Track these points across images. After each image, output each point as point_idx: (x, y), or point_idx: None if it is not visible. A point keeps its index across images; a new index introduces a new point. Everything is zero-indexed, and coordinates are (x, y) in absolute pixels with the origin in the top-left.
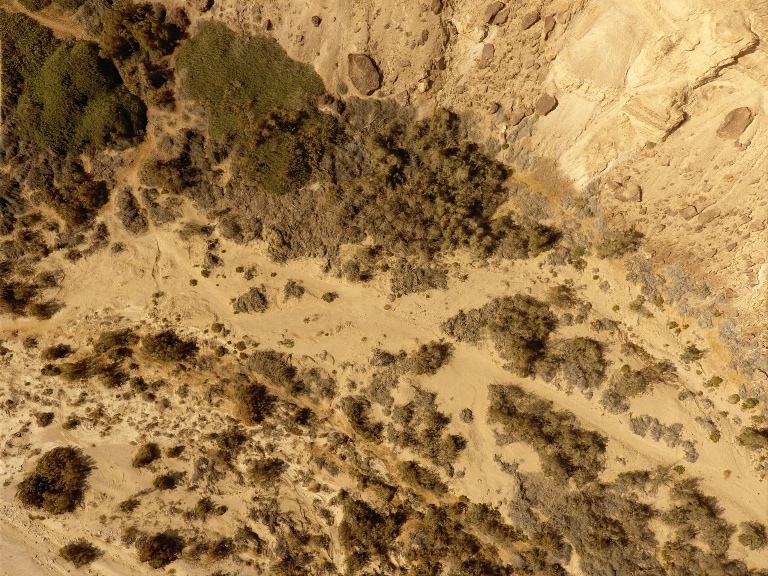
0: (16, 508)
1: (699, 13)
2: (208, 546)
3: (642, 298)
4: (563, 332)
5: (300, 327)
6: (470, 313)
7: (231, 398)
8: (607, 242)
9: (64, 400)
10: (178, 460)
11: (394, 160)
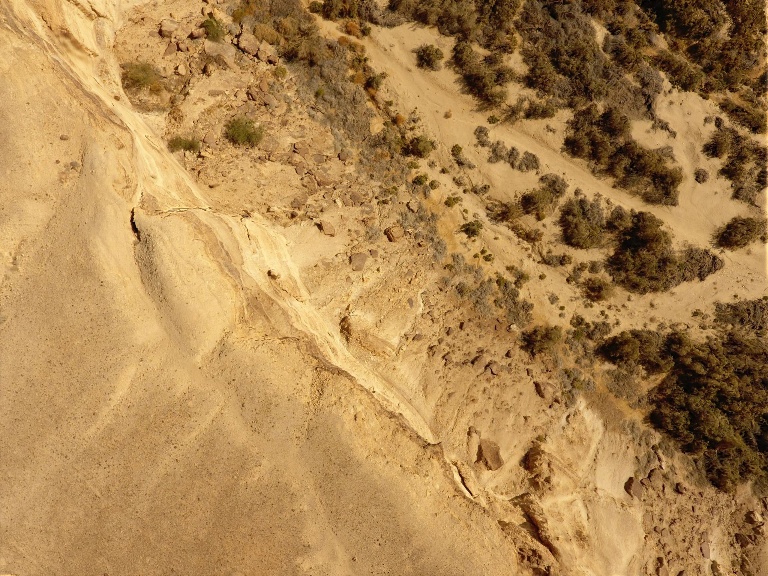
0: None
1: (585, 572)
2: None
3: (519, 286)
4: (600, 255)
5: None
6: None
7: None
8: None
9: None
10: None
11: None
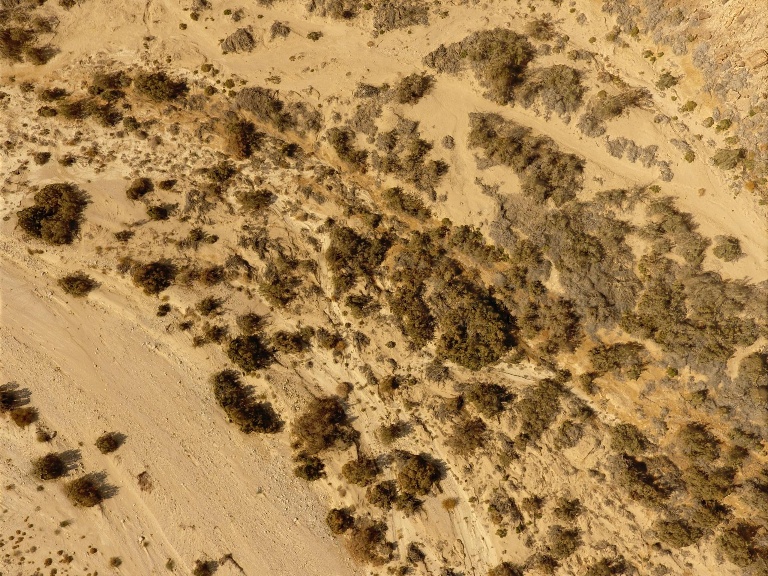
0: (16, 243)
1: None
2: (200, 273)
3: (618, 28)
4: (541, 61)
5: (286, 65)
6: (451, 45)
7: (221, 134)
8: None
9: (60, 139)
10: (170, 192)
11: None
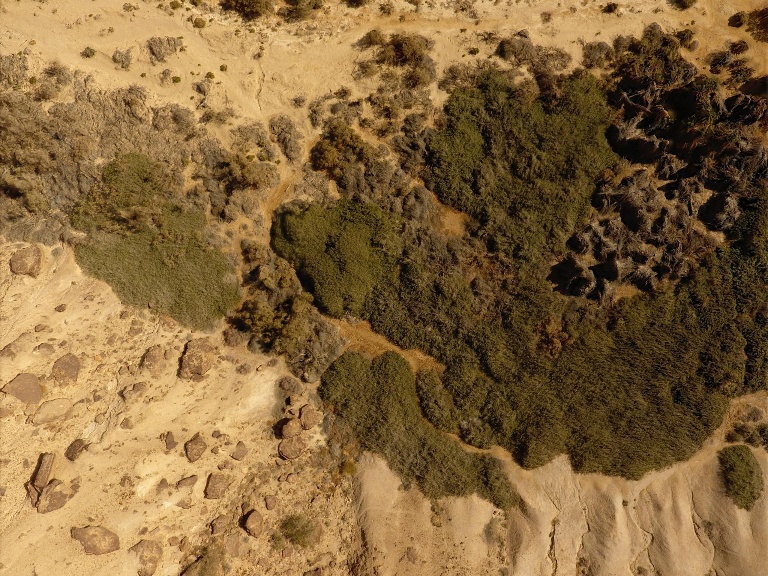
0: None
1: None
2: None
3: None
4: None
5: (118, 24)
6: None
7: None
8: None
9: None
10: None
11: (8, 178)
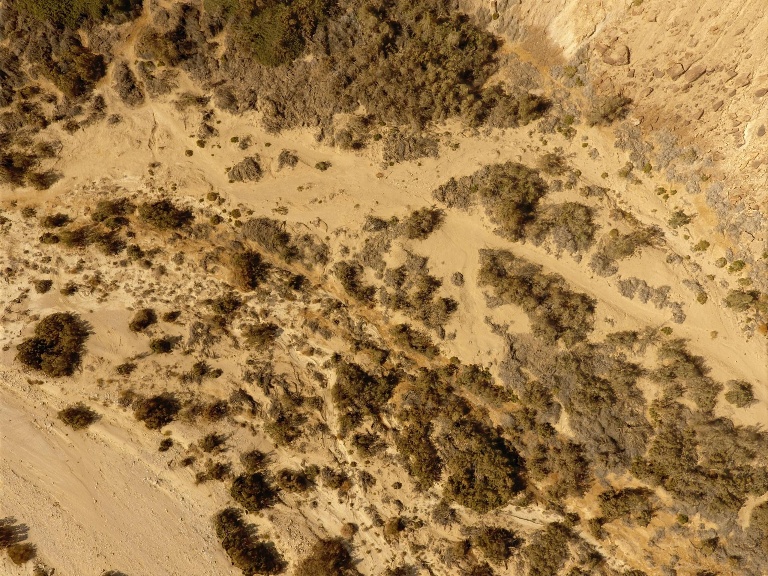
0: (15, 373)
1: None
2: (203, 408)
3: (630, 164)
4: (553, 198)
5: (294, 195)
6: (461, 179)
7: (226, 265)
8: (596, 109)
9: (62, 267)
10: (174, 324)
11: (386, 28)
